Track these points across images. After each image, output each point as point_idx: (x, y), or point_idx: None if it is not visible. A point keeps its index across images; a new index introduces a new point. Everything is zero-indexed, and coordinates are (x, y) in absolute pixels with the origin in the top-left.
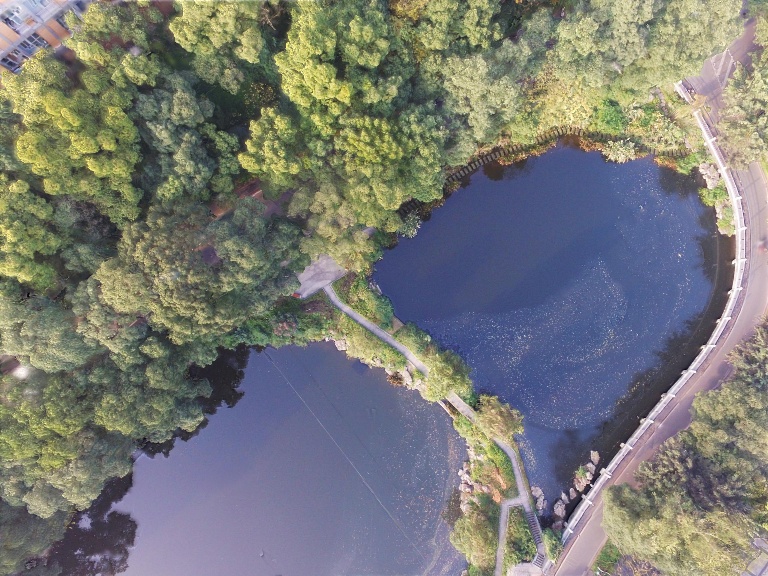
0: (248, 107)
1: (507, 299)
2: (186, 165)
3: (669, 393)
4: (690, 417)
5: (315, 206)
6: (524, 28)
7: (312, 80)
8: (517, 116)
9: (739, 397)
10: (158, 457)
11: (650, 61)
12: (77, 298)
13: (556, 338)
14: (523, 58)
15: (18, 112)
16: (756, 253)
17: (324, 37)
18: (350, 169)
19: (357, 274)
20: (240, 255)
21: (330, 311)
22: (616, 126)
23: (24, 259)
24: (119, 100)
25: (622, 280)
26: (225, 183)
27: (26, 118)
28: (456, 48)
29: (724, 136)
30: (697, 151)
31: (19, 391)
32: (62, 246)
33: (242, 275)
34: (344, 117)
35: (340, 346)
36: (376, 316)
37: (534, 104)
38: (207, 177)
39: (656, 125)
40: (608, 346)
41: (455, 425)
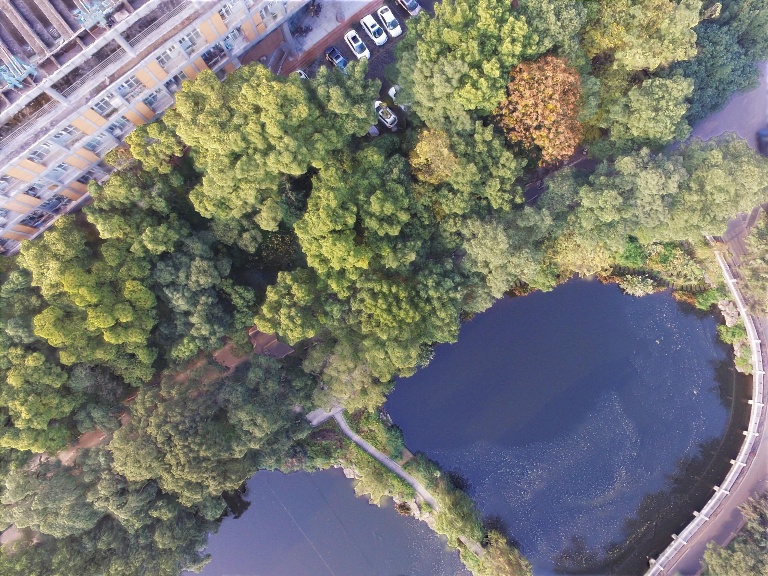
0: (265, 256)
1: (518, 432)
2: (201, 329)
3: (680, 538)
4: (701, 568)
5: (329, 370)
6: (546, 186)
7: (331, 252)
8: None
9: (753, 564)
10: None
11: (673, 223)
12: (89, 465)
13: (567, 473)
14: (544, 225)
15: (36, 285)
16: None
17: (344, 213)
18: (366, 330)
19: None
20: (253, 423)
21: (340, 440)
22: (635, 260)
23: (38, 431)
24: (137, 272)
25: (636, 416)
26: (240, 337)
27: (44, 292)
28: (476, 208)
29: (745, 283)
30: (716, 287)
31: (28, 560)
32: (75, 406)
33: (254, 444)
34: (361, 280)
35: (348, 474)
36: (386, 447)
37: (553, 257)
38: (222, 335)
39: (675, 261)
40: (619, 483)
41: (462, 558)
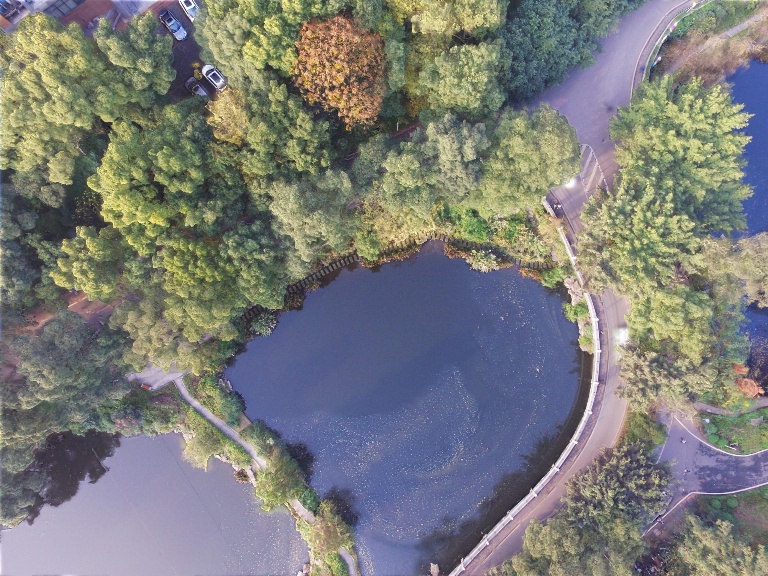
0: (81, 214)
1: (358, 403)
2: None
3: (510, 514)
4: None
5: (126, 326)
6: (360, 152)
7: (119, 207)
8: (357, 234)
9: (558, 538)
10: (22, 524)
11: (486, 192)
12: None
13: (405, 446)
14: (346, 189)
15: None
16: (612, 375)
17: (130, 167)
18: (168, 288)
19: (207, 370)
20: (41, 375)
21: (178, 405)
22: (480, 236)
23: None
24: None
25: (476, 392)
26: (47, 292)
27: None
28: (285, 171)
29: None
30: (563, 265)
31: None
32: None
33: (42, 395)
34: (162, 238)
35: None
36: None
37: (372, 225)
38: (24, 289)
39: (521, 237)
40: (457, 458)
41: (297, 527)
